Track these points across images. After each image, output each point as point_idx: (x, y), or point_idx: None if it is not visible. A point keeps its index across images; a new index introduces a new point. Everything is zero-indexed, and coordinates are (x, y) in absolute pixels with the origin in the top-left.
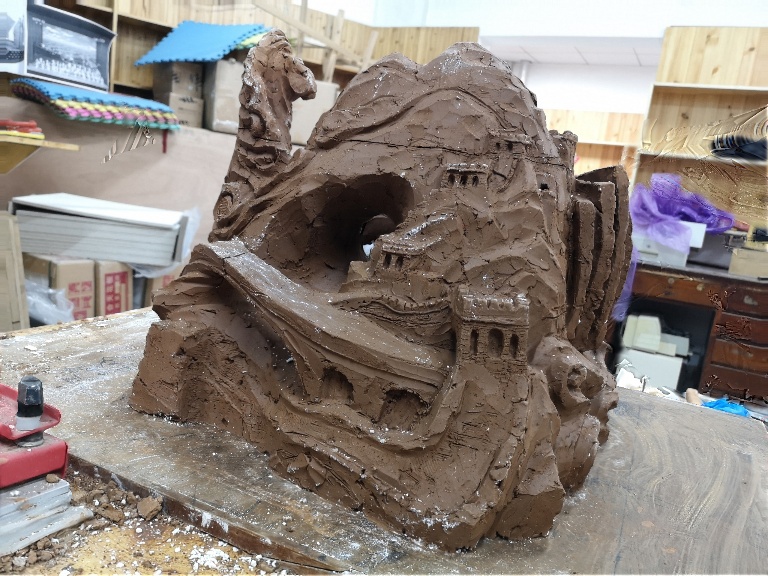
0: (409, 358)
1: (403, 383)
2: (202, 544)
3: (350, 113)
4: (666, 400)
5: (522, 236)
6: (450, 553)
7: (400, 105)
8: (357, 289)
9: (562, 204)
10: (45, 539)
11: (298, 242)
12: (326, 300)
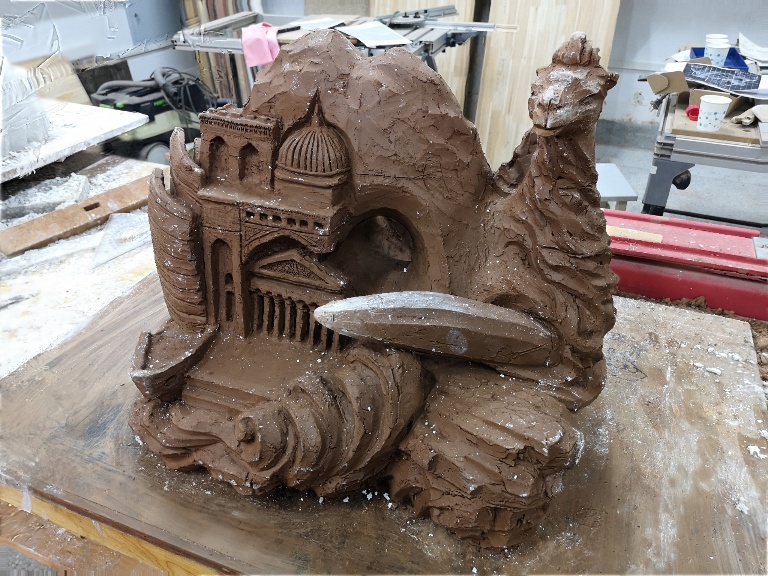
0: None
1: None
2: None
3: None
4: (7, 458)
5: None
6: None
7: None
8: None
9: None
10: None
11: None
12: None
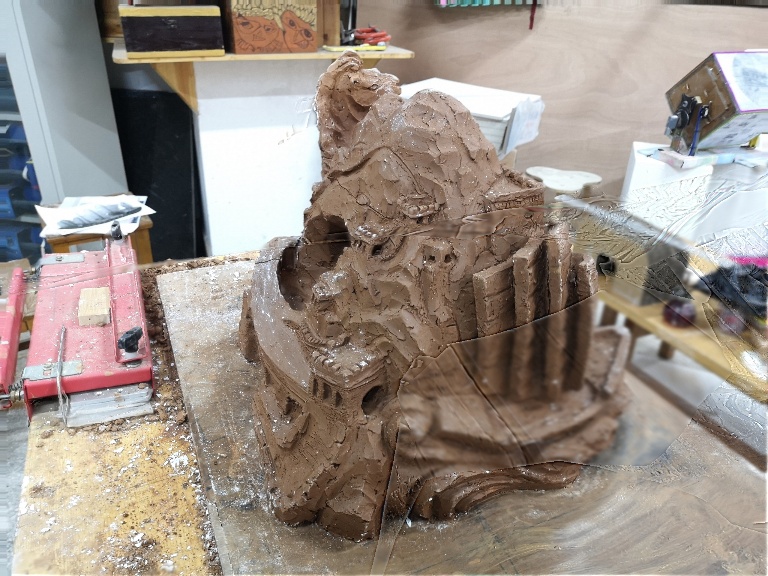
0: (297, 380)
1: (294, 396)
2: (185, 450)
3: (343, 154)
4: None
5: (391, 305)
6: (279, 521)
7: (363, 155)
8: (304, 311)
9: (458, 274)
10: (119, 420)
11: (325, 249)
12: (283, 316)
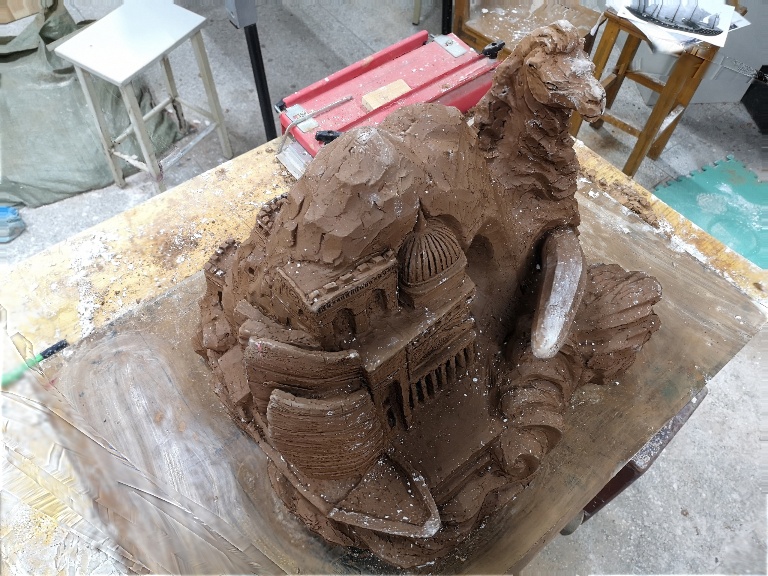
0: None
1: None
2: None
3: None
4: None
5: None
6: None
7: None
8: None
9: None
10: (293, 178)
11: None
12: None
